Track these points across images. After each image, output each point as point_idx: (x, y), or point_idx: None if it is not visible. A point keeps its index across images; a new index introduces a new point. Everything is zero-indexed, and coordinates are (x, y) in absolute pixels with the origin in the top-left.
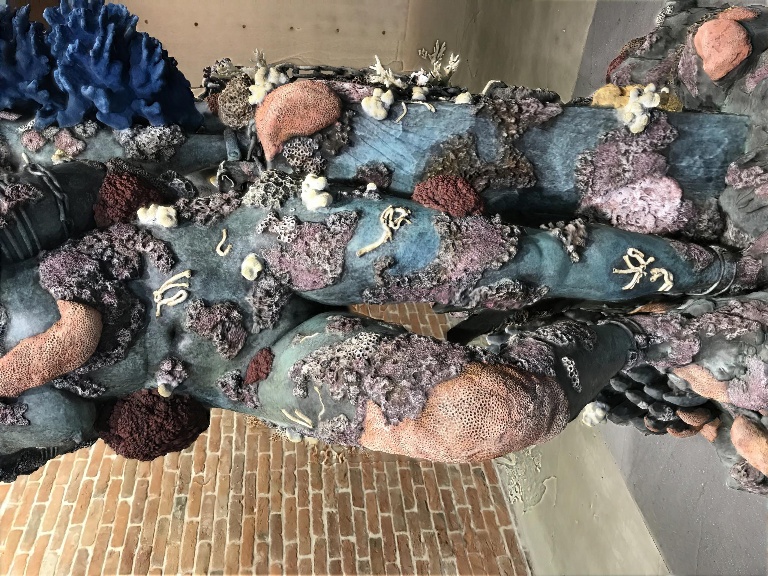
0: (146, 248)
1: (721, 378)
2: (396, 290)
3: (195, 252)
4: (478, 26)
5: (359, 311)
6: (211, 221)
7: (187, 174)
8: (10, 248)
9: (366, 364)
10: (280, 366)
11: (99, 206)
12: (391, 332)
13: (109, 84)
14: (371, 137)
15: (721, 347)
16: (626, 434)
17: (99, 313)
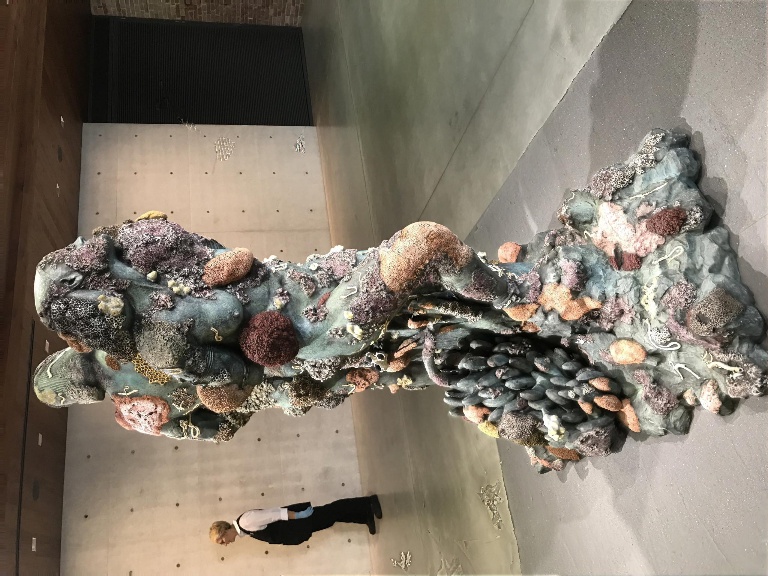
0: None
1: (556, 280)
2: None
3: None
4: (428, 505)
5: None
6: None
7: None
8: None
9: None
10: None
11: None
12: None
13: None
14: None
15: (546, 268)
16: (638, 560)
17: None
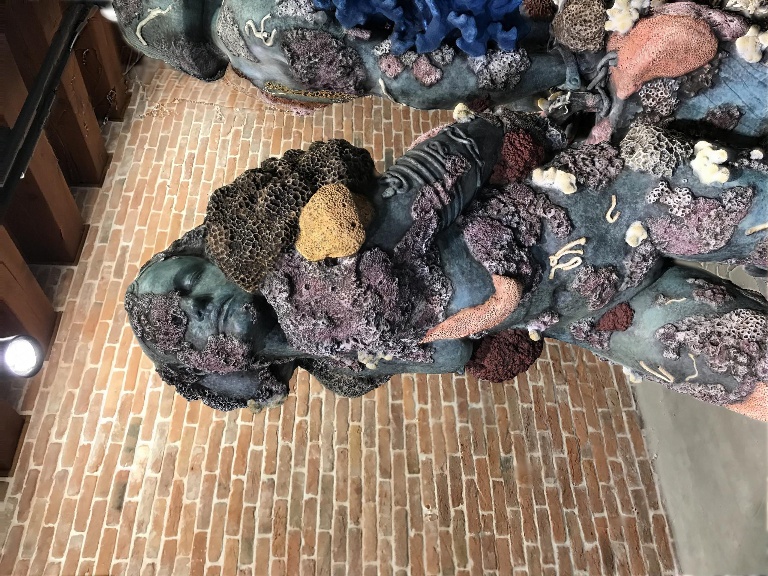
0: (547, 214)
1: None
2: (762, 261)
3: (588, 219)
4: None
5: (705, 268)
6: (601, 186)
7: (521, 98)
8: (446, 219)
9: (757, 348)
10: (643, 324)
11: (500, 167)
12: (767, 310)
13: (472, 7)
14: (734, 79)
15: None
16: None
17: (522, 285)
